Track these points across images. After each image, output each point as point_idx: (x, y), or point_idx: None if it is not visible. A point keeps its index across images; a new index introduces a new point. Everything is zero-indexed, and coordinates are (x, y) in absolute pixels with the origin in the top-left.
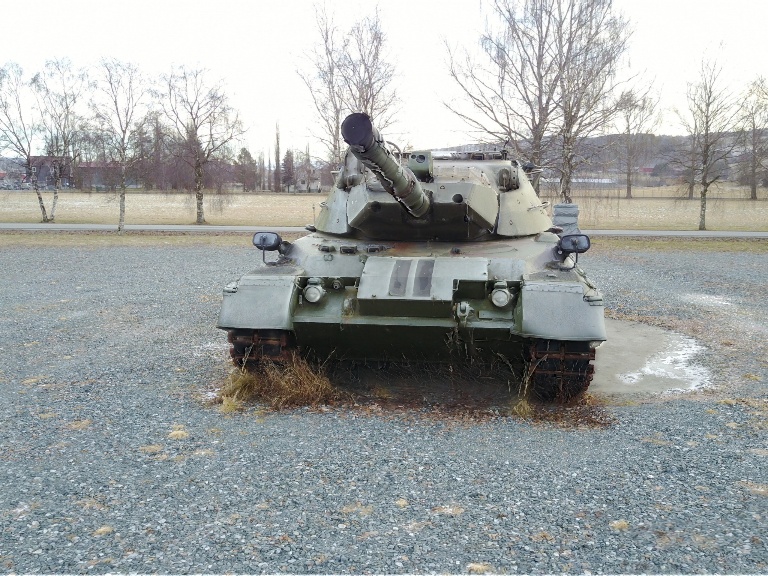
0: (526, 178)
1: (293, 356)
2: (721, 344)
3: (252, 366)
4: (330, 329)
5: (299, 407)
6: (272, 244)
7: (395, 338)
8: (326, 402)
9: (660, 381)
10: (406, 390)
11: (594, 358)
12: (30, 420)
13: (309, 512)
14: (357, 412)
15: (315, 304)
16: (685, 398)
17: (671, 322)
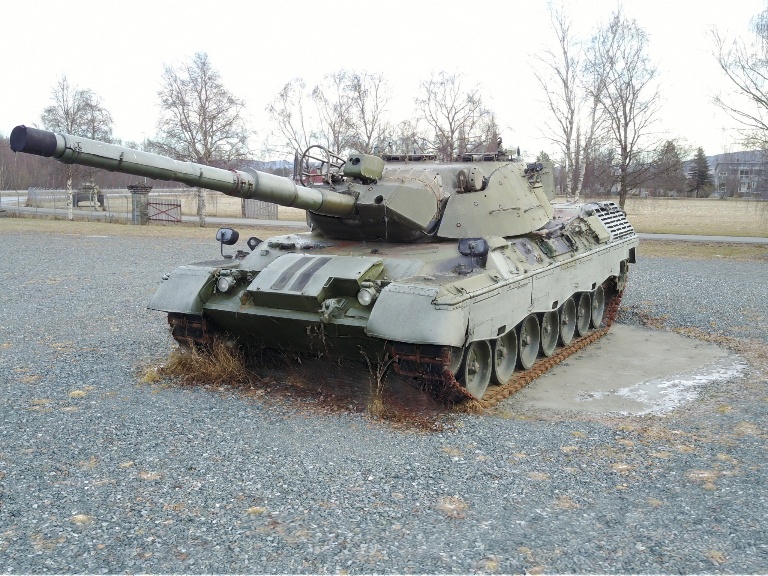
0: (513, 180)
1: (214, 339)
2: (763, 373)
3: (188, 346)
4: (234, 317)
5: (202, 384)
6: (229, 239)
7: (288, 329)
8: (230, 383)
9: (617, 402)
10: (342, 383)
11: (448, 364)
12: (4, 372)
13: (52, 460)
14: (241, 394)
15: (228, 294)
16: (597, 420)
17: (747, 345)
